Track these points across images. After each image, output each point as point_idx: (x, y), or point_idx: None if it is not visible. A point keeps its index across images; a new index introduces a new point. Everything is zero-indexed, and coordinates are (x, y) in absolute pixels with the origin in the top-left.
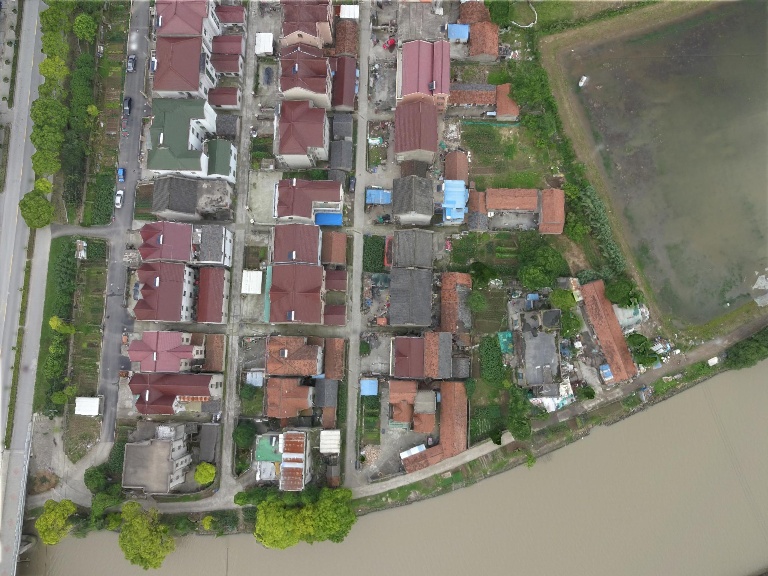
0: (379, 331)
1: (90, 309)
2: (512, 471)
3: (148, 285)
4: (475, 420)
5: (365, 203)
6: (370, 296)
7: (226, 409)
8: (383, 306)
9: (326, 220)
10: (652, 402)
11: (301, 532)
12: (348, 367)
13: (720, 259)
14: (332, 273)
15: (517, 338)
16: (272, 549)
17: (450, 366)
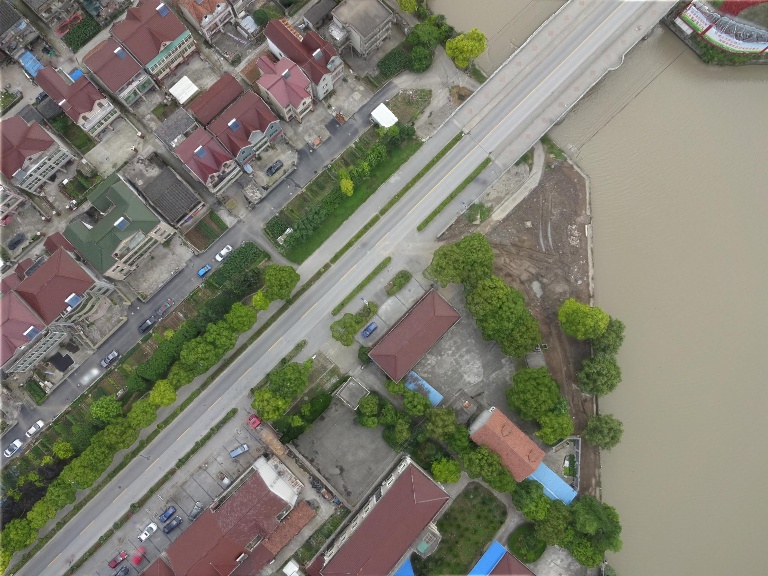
0: None
1: None
2: None
3: (246, 135)
4: None
5: None
6: (113, 4)
7: None
8: None
9: None
10: None
11: None
12: None
13: None
14: None
15: None
16: None
17: None
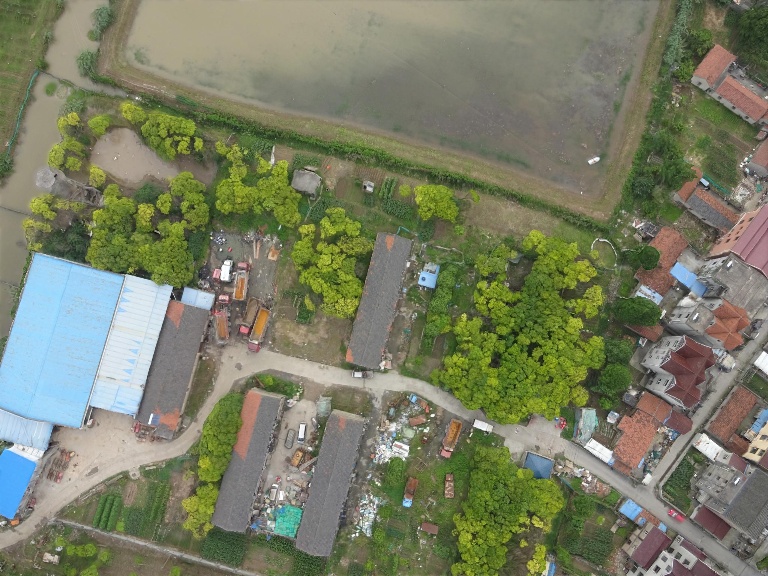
0: None
1: None
2: None
3: None
4: None
5: None
6: None
7: None
8: None
9: None
10: None
11: None
12: None
13: None
14: None
15: None
16: None
17: None
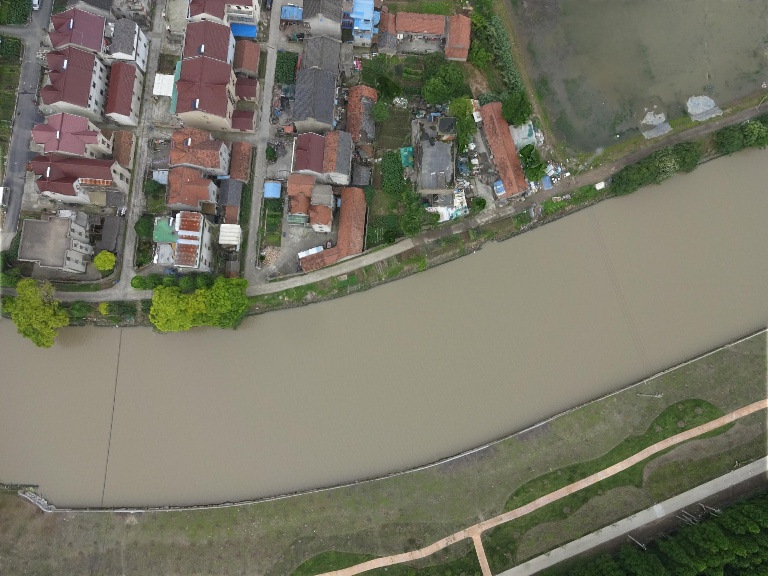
0: (286, 140)
1: (1, 105)
2: (406, 279)
3: (57, 71)
4: (373, 228)
5: (281, 21)
6: (279, 105)
7: (131, 206)
8: (291, 117)
9: (240, 31)
10: (542, 222)
11: (193, 309)
12: (254, 173)
13: (613, 95)
14: (243, 80)
15: (417, 150)
16: (166, 334)
17: (348, 164)
